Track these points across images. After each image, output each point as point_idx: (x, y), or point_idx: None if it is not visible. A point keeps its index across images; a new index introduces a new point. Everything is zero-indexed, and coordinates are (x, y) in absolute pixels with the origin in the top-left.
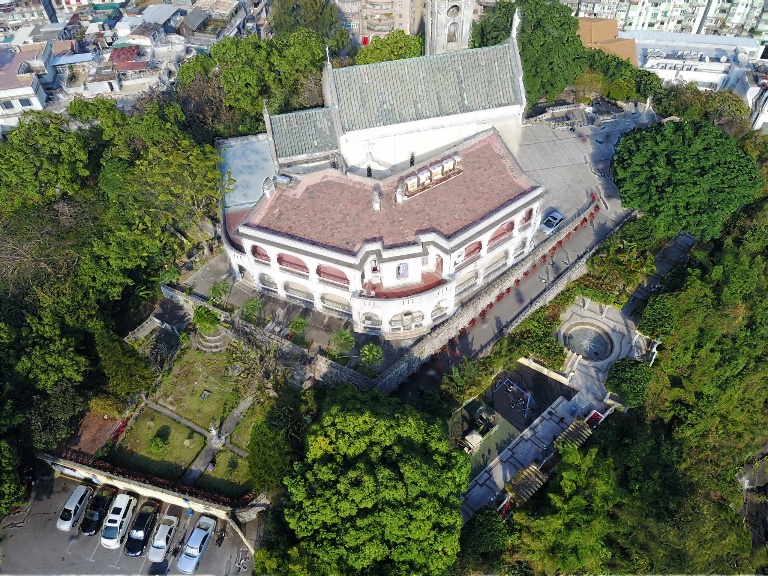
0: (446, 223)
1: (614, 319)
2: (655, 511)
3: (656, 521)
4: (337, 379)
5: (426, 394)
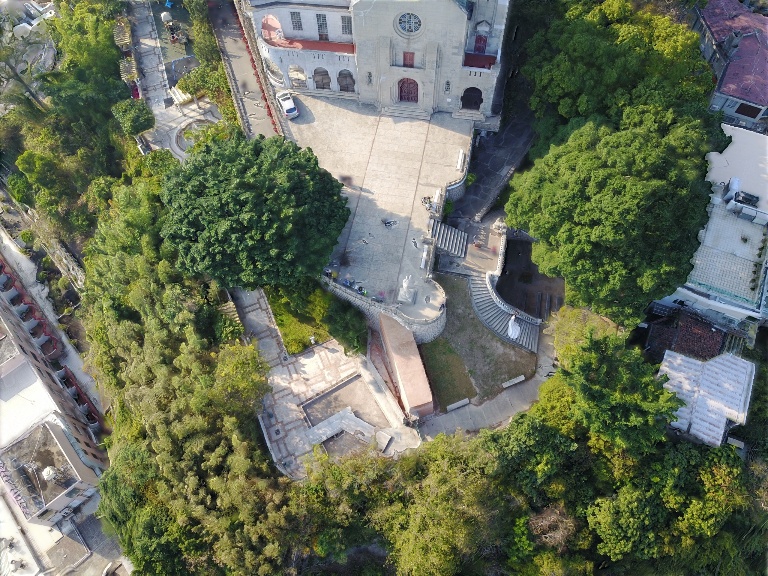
0: None
1: None
2: None
3: None
4: None
5: None
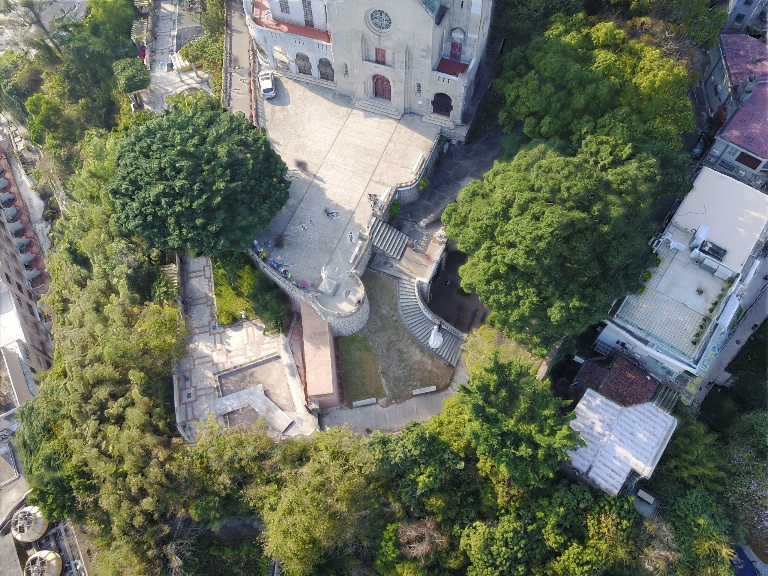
0: None
1: None
2: None
3: None
4: None
5: None
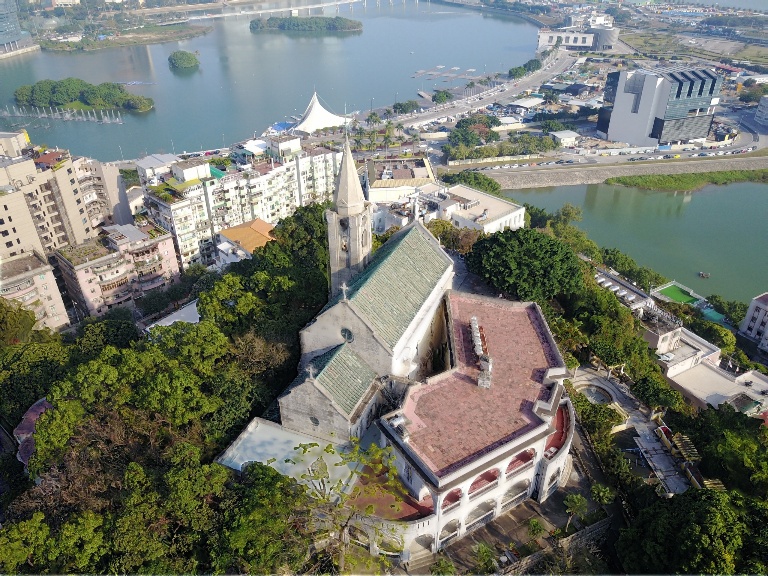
0: (534, 361)
1: (580, 374)
2: (759, 444)
3: (763, 450)
4: (575, 551)
5: (637, 493)
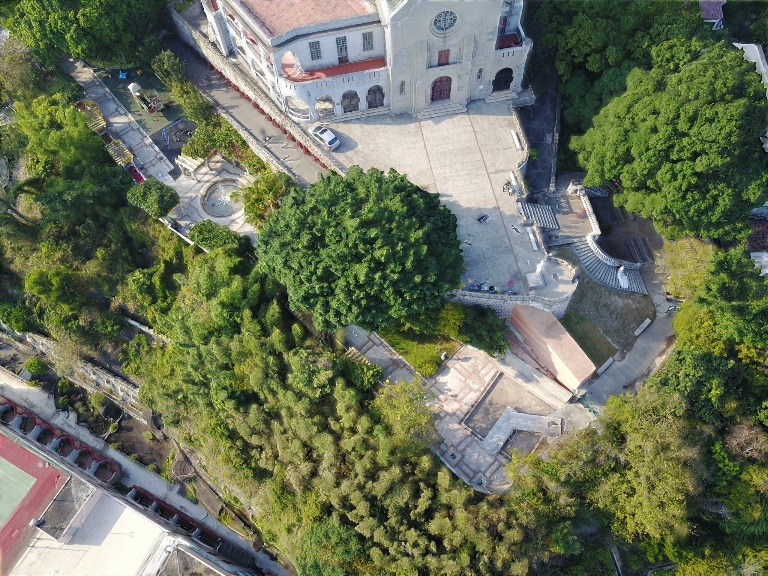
0: None
1: (246, 224)
2: None
3: None
4: None
5: None
